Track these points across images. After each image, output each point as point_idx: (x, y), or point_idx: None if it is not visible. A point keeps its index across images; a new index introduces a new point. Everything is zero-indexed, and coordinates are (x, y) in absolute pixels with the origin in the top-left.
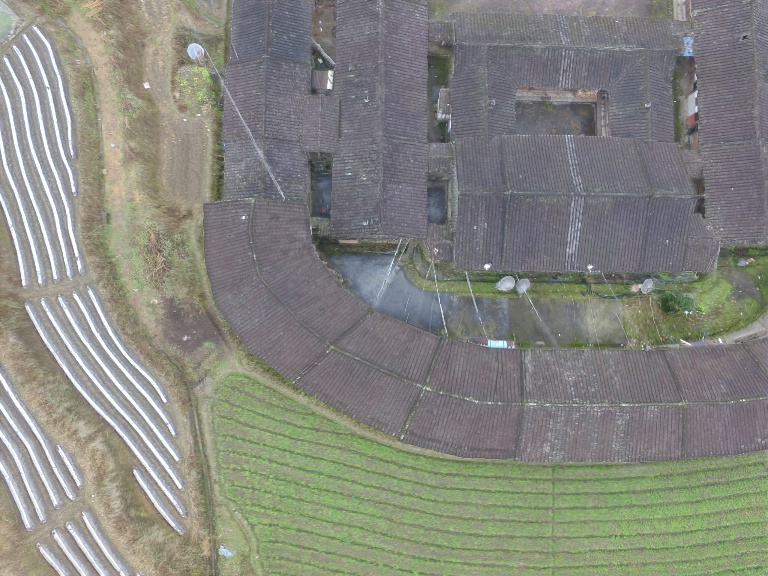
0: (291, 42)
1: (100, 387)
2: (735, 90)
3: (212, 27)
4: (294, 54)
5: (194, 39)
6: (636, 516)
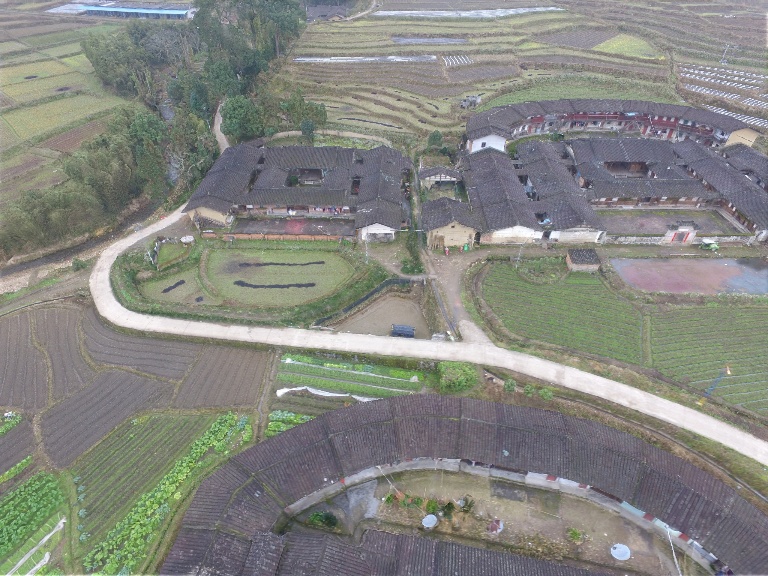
0: None
1: None
2: None
3: None
4: None
5: None
6: None
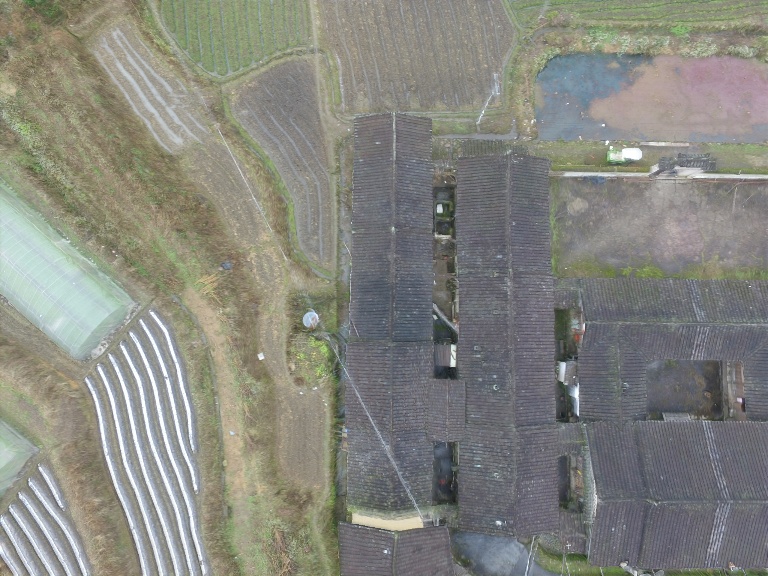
0: (414, 320)
1: None
2: None
3: (323, 284)
4: (417, 332)
5: (308, 305)
6: None
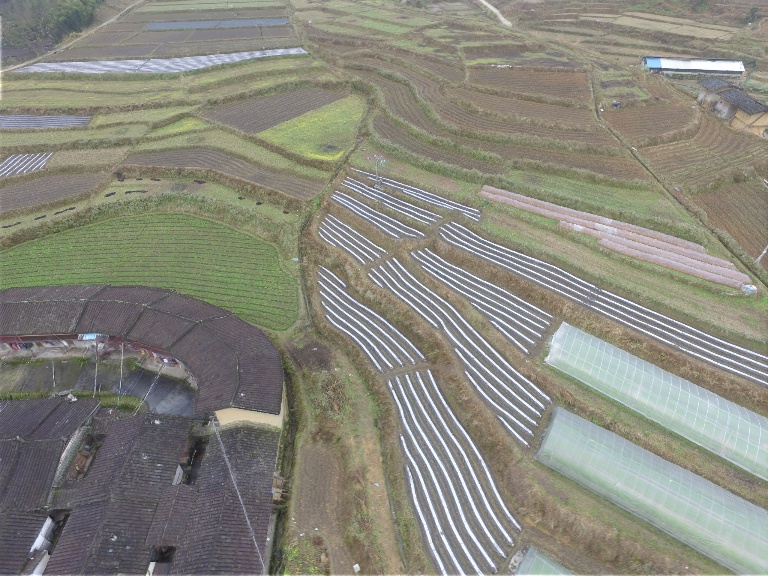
0: None
1: (368, 320)
2: None
3: None
4: None
5: None
6: (59, 281)
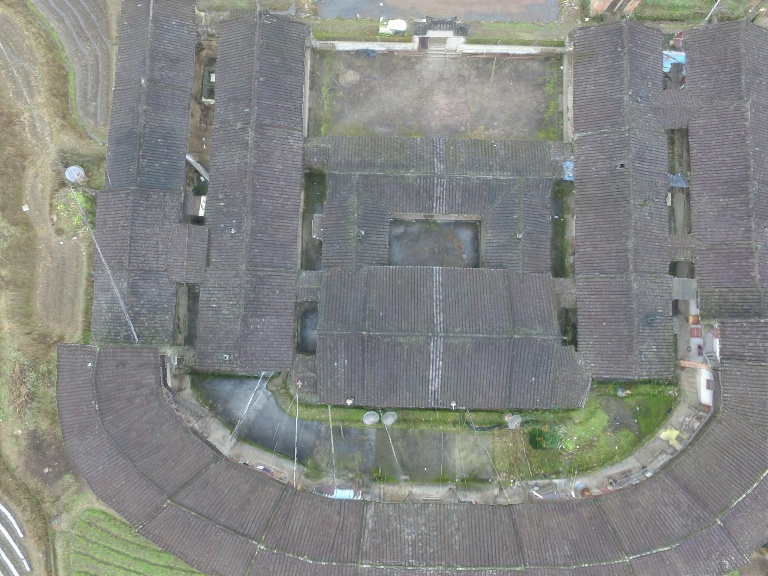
0: (163, 169)
1: None
2: (611, 220)
3: (96, 145)
4: (166, 181)
5: (74, 161)
6: None
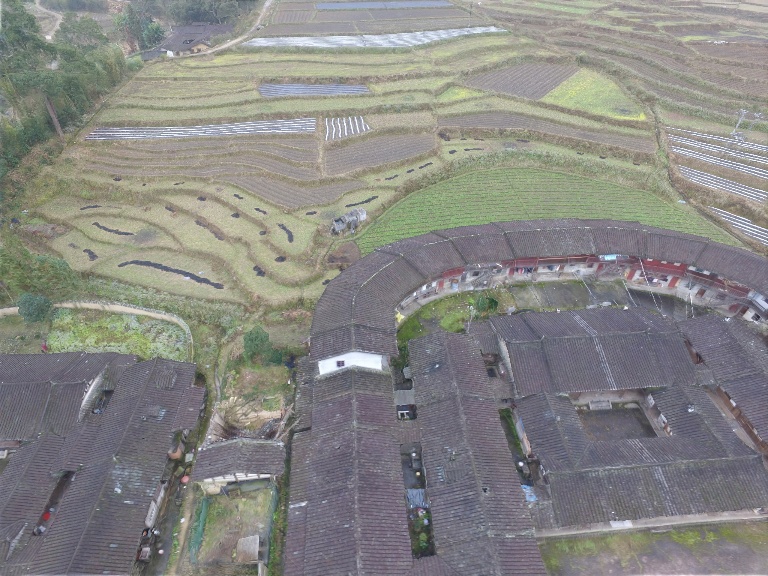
0: None
1: None
2: (482, 440)
3: None
4: None
5: None
6: (488, 221)
